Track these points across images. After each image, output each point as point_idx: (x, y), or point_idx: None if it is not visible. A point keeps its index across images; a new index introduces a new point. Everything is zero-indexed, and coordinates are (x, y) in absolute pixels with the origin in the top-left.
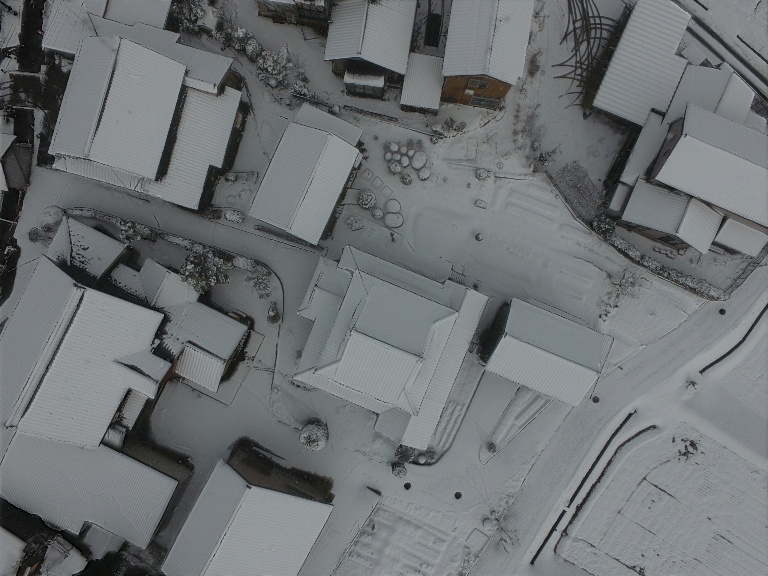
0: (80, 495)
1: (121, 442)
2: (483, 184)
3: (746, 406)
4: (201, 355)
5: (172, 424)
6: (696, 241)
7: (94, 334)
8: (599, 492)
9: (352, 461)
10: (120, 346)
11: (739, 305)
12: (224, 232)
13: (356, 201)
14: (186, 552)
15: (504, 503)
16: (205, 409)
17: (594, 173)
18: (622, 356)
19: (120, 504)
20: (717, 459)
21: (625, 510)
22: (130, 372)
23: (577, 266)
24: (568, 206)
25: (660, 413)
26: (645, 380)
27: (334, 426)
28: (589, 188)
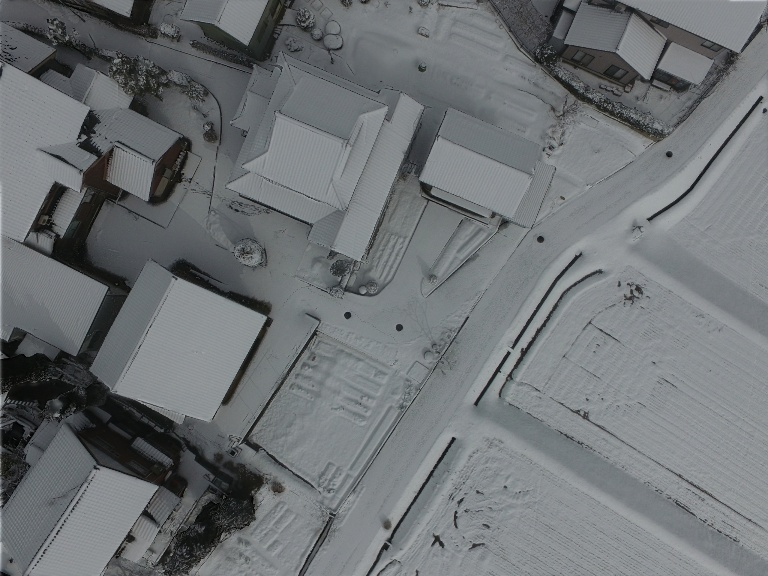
0: (5, 289)
1: (51, 248)
2: (426, 12)
3: (694, 256)
4: (130, 156)
5: (108, 246)
6: (637, 63)
7: (15, 116)
8: (544, 336)
9: (291, 287)
10: (43, 134)
11: (686, 148)
12: (161, 53)
13: (295, 21)
14: (113, 349)
15: (446, 337)
16: (142, 232)
17: (541, 9)
18: (567, 196)
19: (50, 310)
20: (662, 303)
21: (570, 354)
22: (54, 161)
23: (521, 98)
24: (512, 36)
25: (605, 255)
26: (590, 220)
27: (273, 251)
28: (532, 14)
